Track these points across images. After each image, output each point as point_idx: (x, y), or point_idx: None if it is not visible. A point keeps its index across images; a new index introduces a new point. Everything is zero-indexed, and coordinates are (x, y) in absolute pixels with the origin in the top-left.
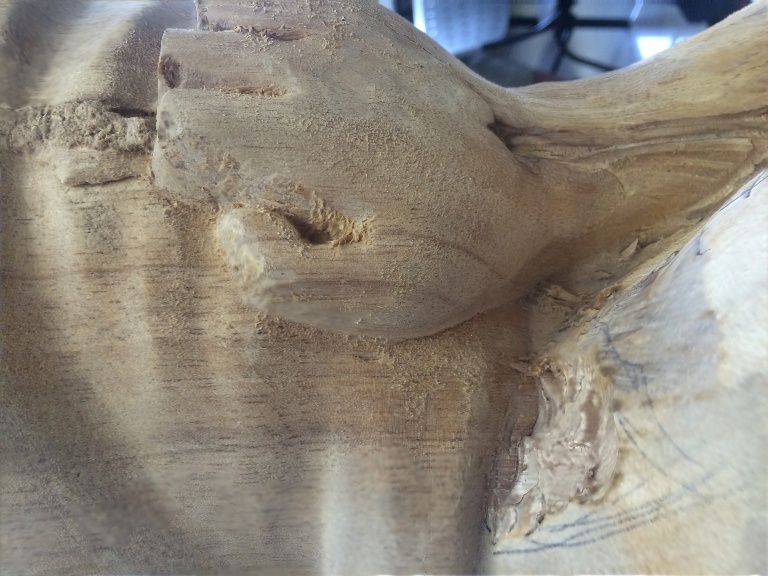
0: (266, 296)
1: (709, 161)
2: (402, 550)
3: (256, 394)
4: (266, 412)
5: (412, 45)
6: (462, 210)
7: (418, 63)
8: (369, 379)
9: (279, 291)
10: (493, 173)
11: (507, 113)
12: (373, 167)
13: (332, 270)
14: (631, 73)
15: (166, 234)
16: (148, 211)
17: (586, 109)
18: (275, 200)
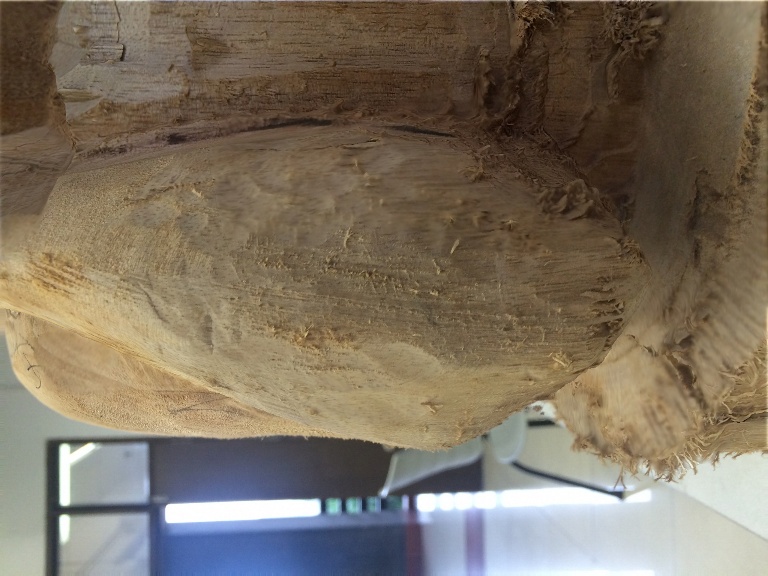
0: None
1: None
2: None
3: None
4: None
5: None
6: None
7: None
8: None
9: None
10: None
11: None
12: None
13: None
14: None
15: None
16: None
17: None
18: None
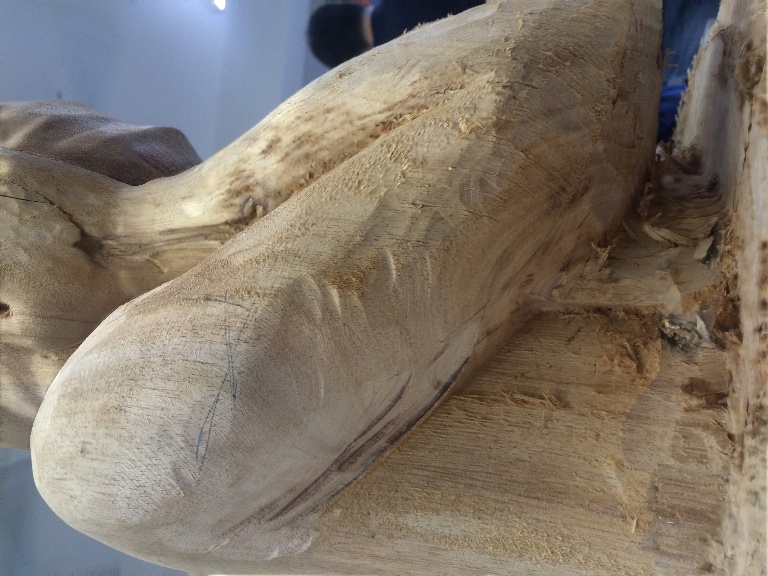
0: None
1: (202, 253)
2: None
3: (4, 371)
4: (11, 378)
5: (36, 198)
6: (53, 299)
7: (31, 216)
8: (48, 367)
9: None
10: (72, 275)
11: (92, 230)
12: (4, 285)
13: (2, 330)
14: (183, 181)
15: None
16: None
17: (146, 216)
18: None
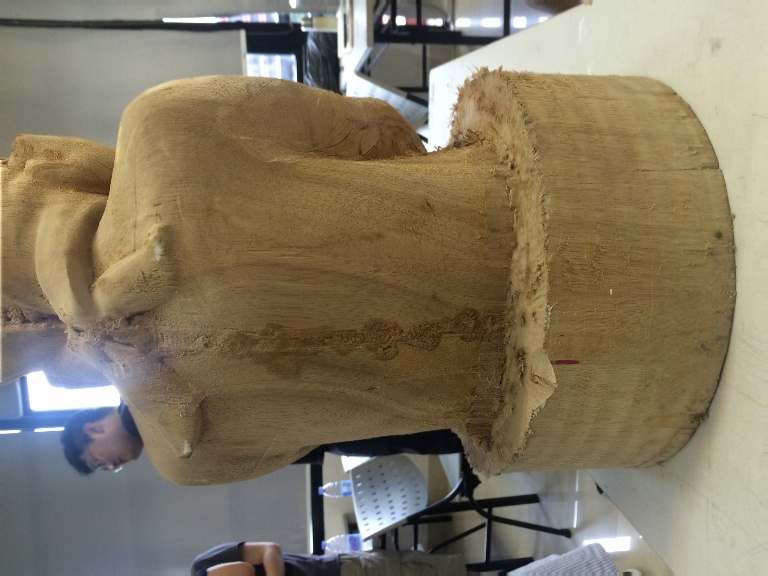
0: (32, 170)
1: None
2: (61, 223)
3: (21, 192)
4: (24, 197)
5: None
6: (105, 158)
7: None
8: (64, 194)
9: (36, 167)
10: None
11: None
12: None
13: None
14: None
15: (6, 170)
16: (3, 168)
17: None
18: (44, 158)
